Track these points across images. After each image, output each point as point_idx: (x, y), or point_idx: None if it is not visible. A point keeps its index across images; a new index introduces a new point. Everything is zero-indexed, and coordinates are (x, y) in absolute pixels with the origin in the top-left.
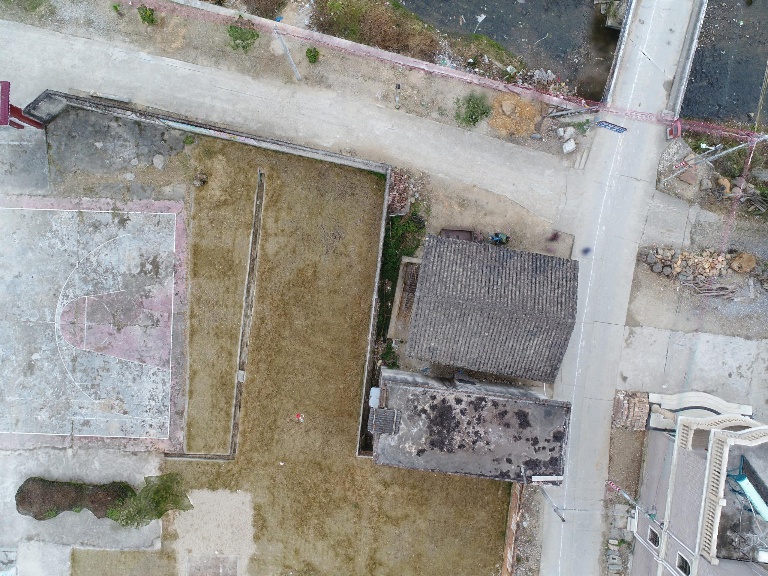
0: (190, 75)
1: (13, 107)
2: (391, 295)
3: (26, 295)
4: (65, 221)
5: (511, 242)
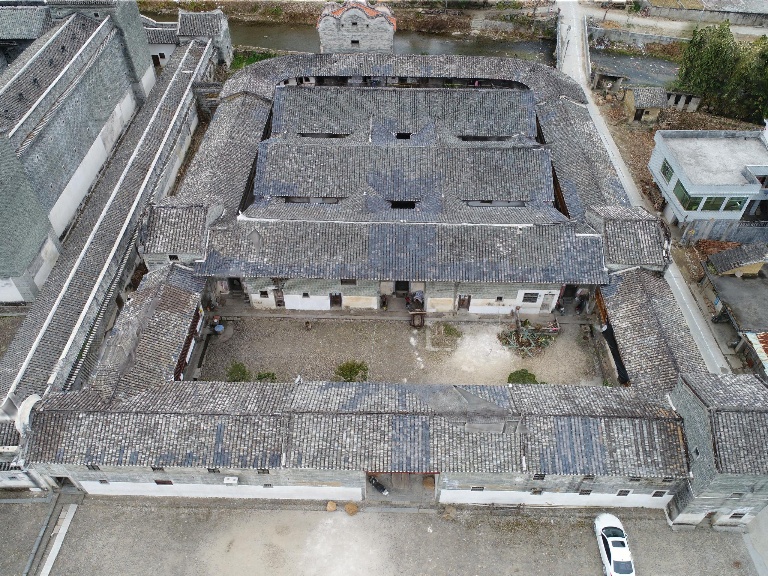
0: None
1: None
2: None
3: (757, 4)
4: None
5: None
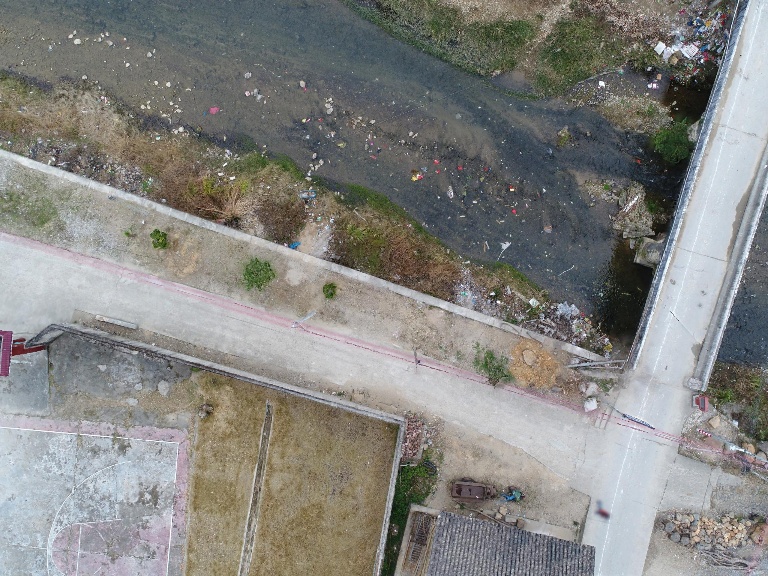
0: (201, 303)
1: (15, 347)
2: (397, 540)
3: (18, 519)
4: (63, 444)
5: (525, 496)
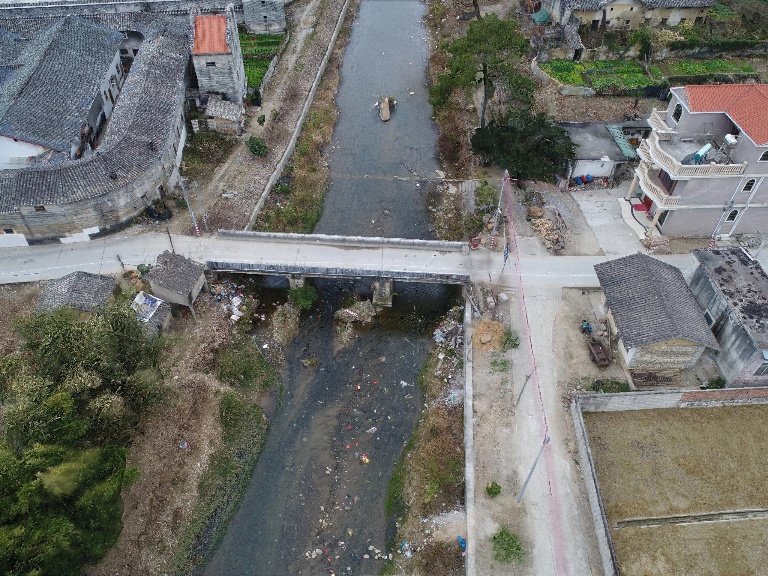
0: None
1: None
2: None
3: None
4: None
5: None
